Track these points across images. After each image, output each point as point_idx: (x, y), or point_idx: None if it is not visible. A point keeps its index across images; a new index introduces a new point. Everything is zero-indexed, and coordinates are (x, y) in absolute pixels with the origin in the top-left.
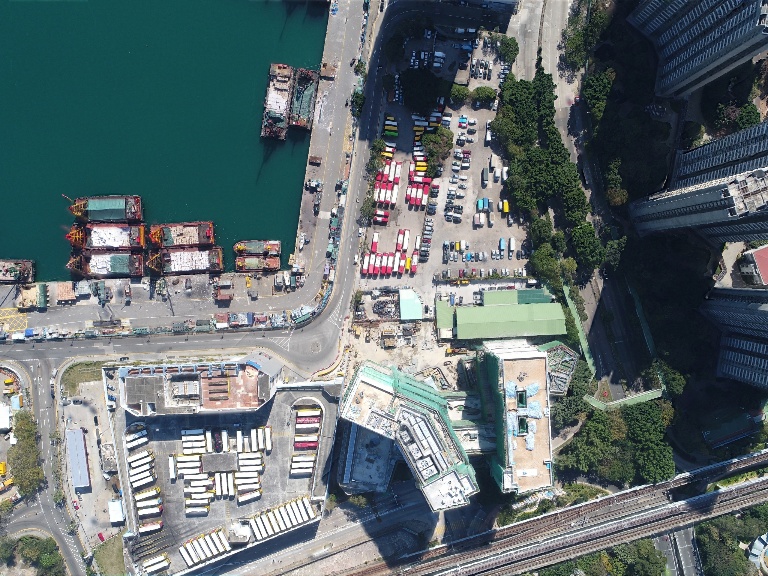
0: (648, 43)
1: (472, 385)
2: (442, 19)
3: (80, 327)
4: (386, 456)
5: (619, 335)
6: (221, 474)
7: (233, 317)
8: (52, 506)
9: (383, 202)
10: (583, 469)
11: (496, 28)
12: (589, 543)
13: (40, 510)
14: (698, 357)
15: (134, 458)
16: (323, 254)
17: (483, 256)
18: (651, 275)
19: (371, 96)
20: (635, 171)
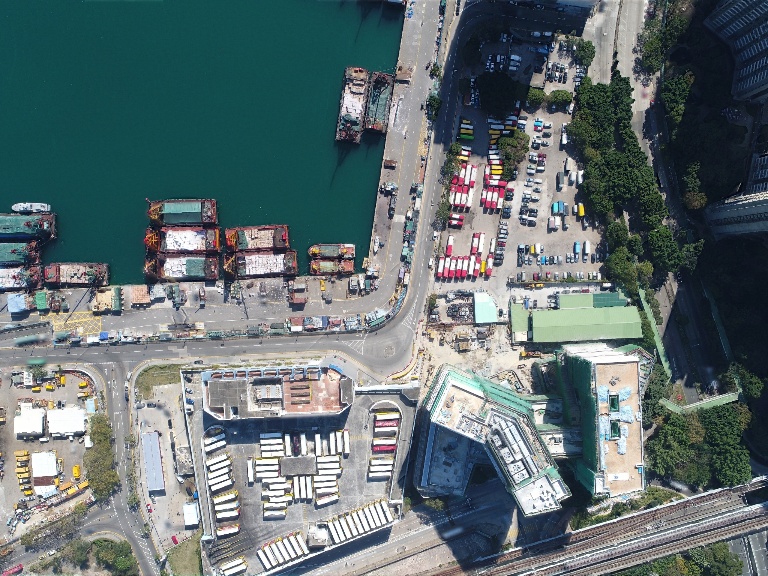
0: (724, 46)
1: (548, 388)
2: (518, 22)
3: (154, 330)
4: (464, 459)
5: (693, 338)
6: (300, 477)
7: (308, 320)
8: (126, 509)
9: (458, 205)
10: (660, 472)
11: (573, 31)
12: (664, 546)
13: (114, 513)
14: None
15: (213, 461)
16: (397, 257)
17: (558, 259)
18: (731, 279)
19: (446, 99)
20: (714, 175)
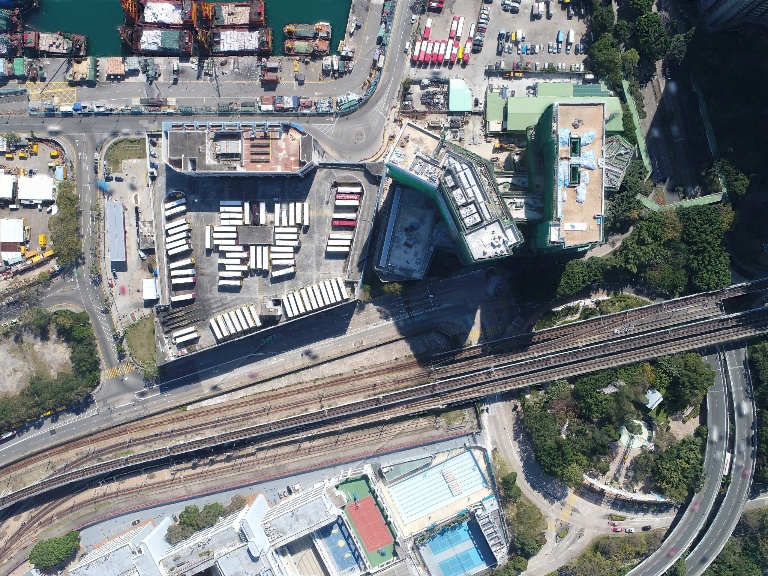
0: None
1: None
2: None
3: (127, 104)
4: (425, 241)
5: None
6: (256, 247)
7: (278, 99)
8: (88, 282)
9: None
10: (631, 270)
11: None
12: (632, 353)
13: (76, 286)
14: (764, 163)
15: (171, 225)
16: (374, 40)
17: (539, 48)
18: (720, 61)
19: None
20: None
